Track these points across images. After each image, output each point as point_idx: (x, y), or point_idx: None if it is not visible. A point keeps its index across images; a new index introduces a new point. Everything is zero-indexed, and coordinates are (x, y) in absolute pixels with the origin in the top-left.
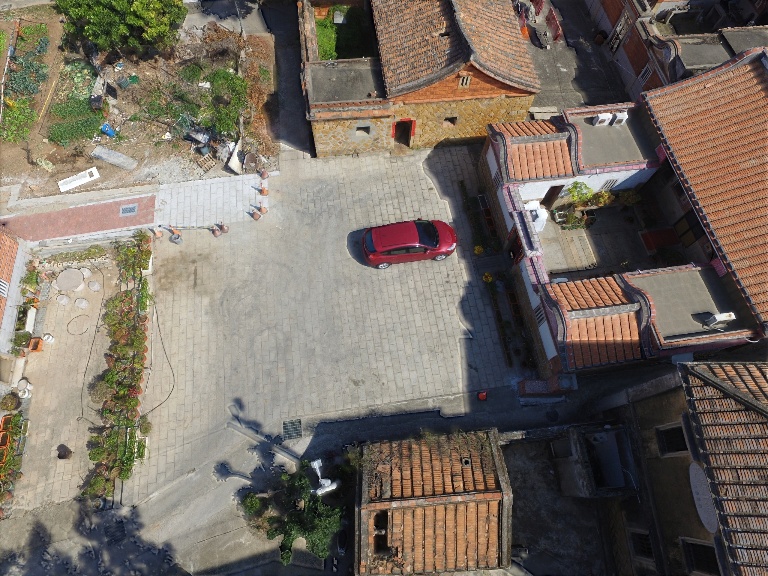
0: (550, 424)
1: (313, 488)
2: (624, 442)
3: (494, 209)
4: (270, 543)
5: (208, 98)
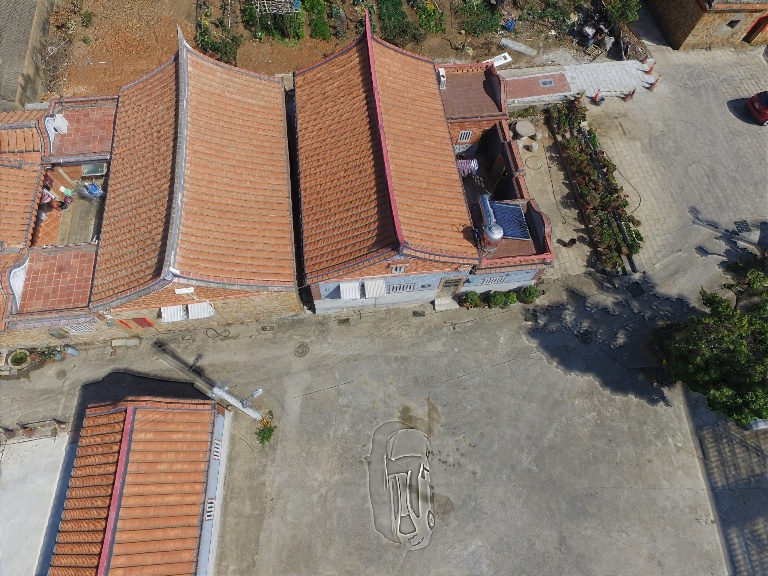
0: None
1: None
2: None
3: None
4: None
5: (571, 6)
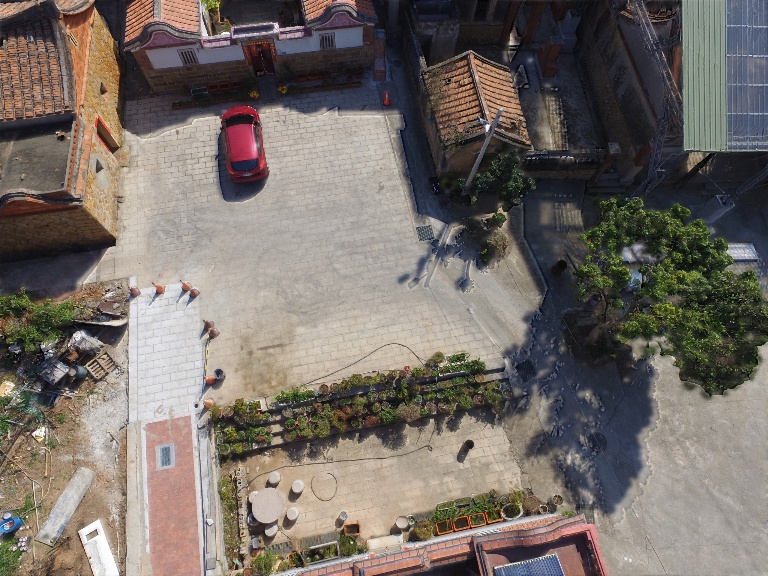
0: (404, 65)
1: (469, 213)
2: (422, 5)
3: (212, 78)
4: (513, 240)
5: None
